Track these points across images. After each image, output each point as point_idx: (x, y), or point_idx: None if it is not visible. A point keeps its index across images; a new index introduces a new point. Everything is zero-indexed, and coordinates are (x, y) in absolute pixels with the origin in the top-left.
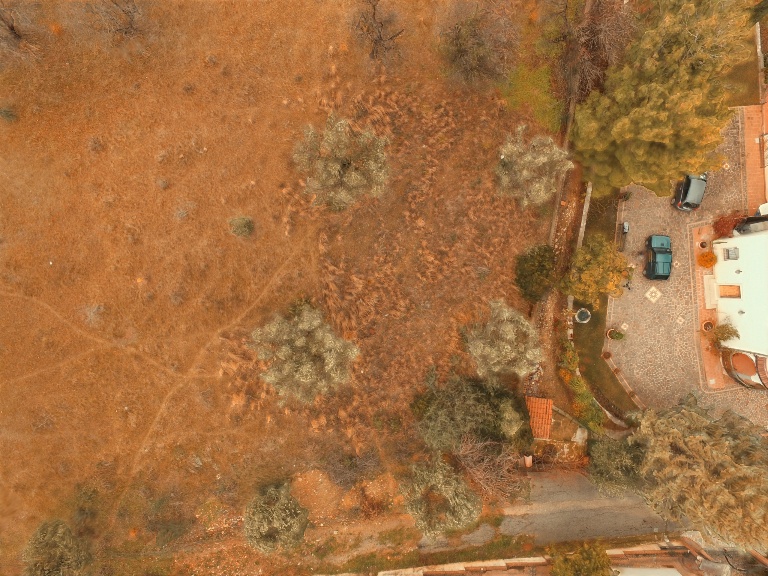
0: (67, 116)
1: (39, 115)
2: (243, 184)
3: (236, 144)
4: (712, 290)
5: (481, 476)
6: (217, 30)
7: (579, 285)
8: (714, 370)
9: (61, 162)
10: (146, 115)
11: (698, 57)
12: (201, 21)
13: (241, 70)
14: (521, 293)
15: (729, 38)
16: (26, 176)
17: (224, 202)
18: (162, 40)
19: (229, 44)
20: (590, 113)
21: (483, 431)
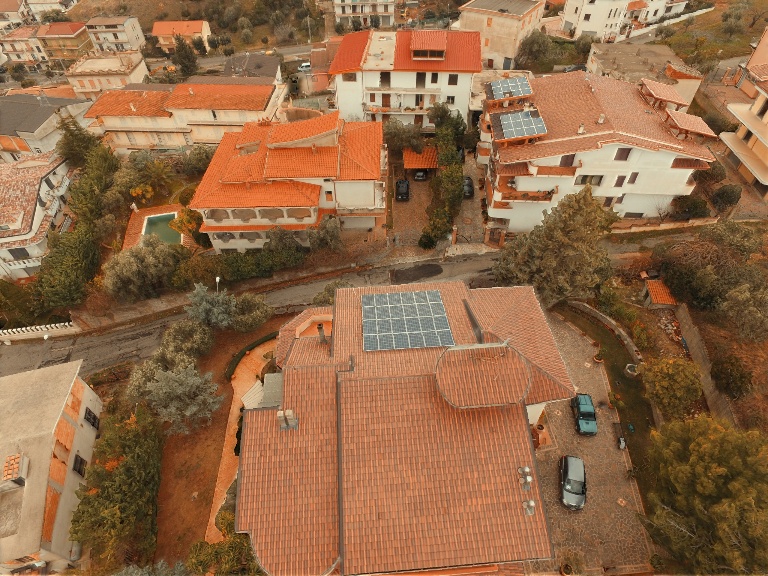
0: None
1: None
2: None
3: None
4: None
5: (714, 247)
6: None
7: None
8: None
9: None
10: None
11: None
12: None
13: None
14: None
15: None
16: None
17: None
18: None
19: None
20: None
21: (718, 274)
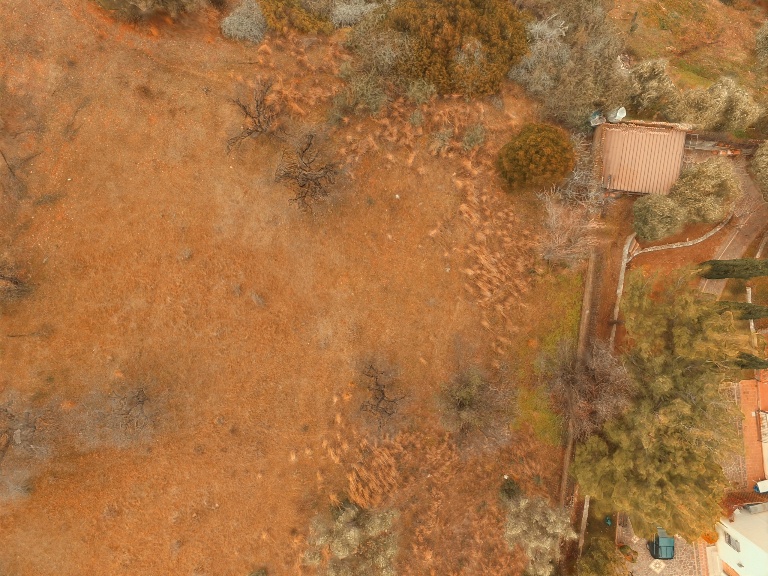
0: (82, 483)
1: (55, 485)
2: (255, 534)
3: (247, 497)
4: (715, 562)
5: None
6: (224, 389)
7: None
8: None
9: (78, 528)
10: (158, 478)
11: None
12: (208, 381)
13: (249, 426)
14: None
15: None
16: (45, 544)
17: (237, 553)
18: (171, 403)
19: (236, 402)
20: (590, 470)
21: None
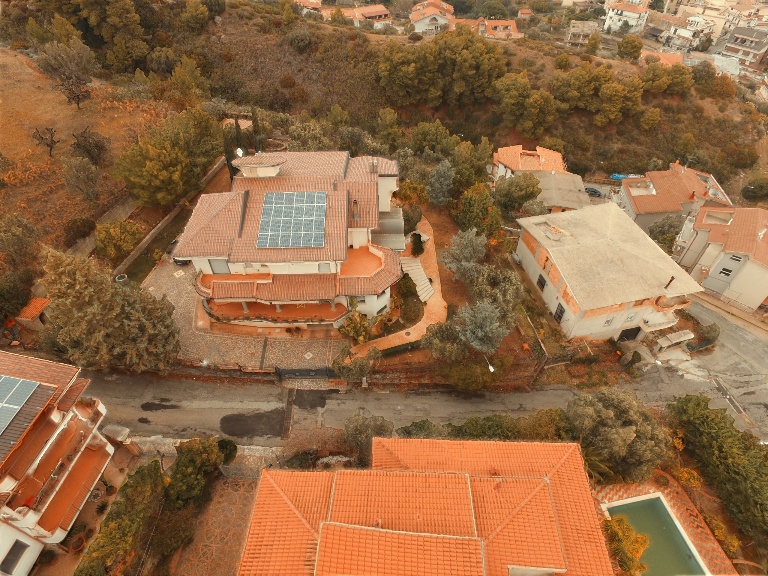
0: None
1: None
2: None
3: None
4: None
5: None
6: None
7: (96, 233)
8: (204, 316)
9: None
10: None
11: (165, 136)
12: None
13: None
14: (64, 241)
15: (178, 130)
16: None
17: None
18: None
19: None
20: None
21: None
